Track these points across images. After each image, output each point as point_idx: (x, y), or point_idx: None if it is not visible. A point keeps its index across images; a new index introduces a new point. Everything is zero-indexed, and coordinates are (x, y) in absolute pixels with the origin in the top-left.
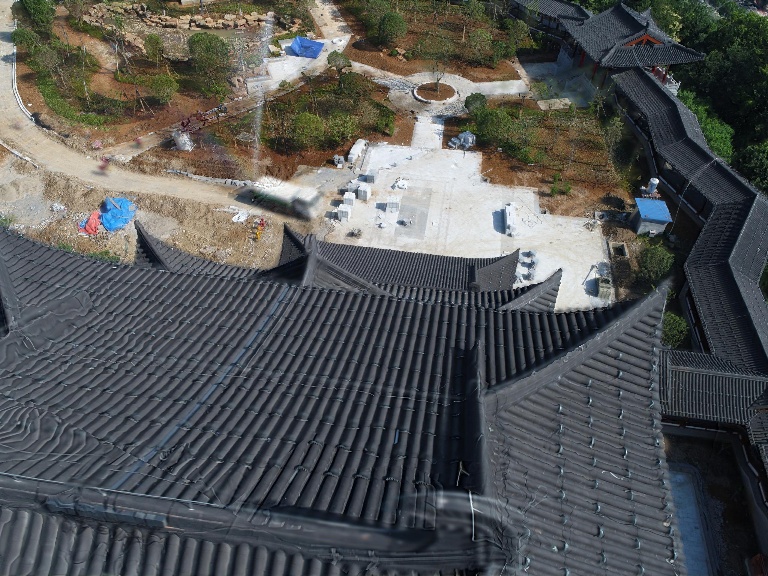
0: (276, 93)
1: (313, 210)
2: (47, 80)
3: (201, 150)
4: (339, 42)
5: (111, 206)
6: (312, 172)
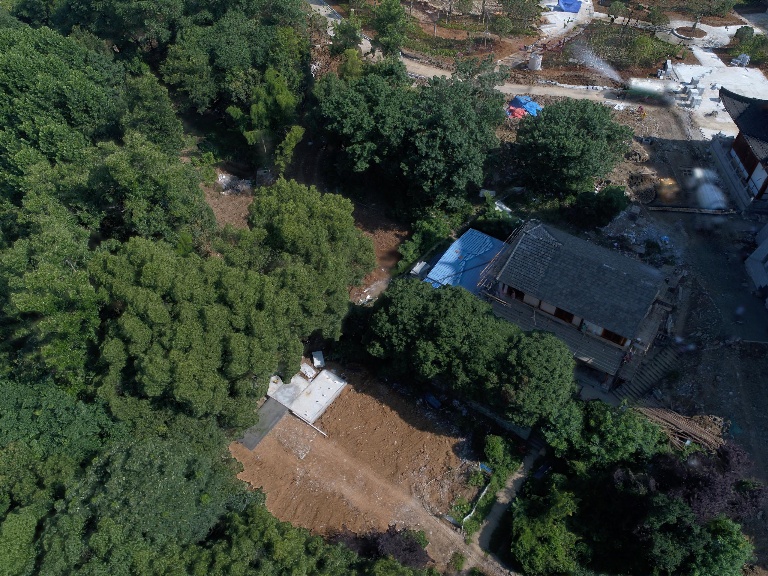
0: (568, 35)
1: (667, 103)
2: None
3: (550, 69)
4: (587, 2)
5: (524, 101)
6: (644, 81)
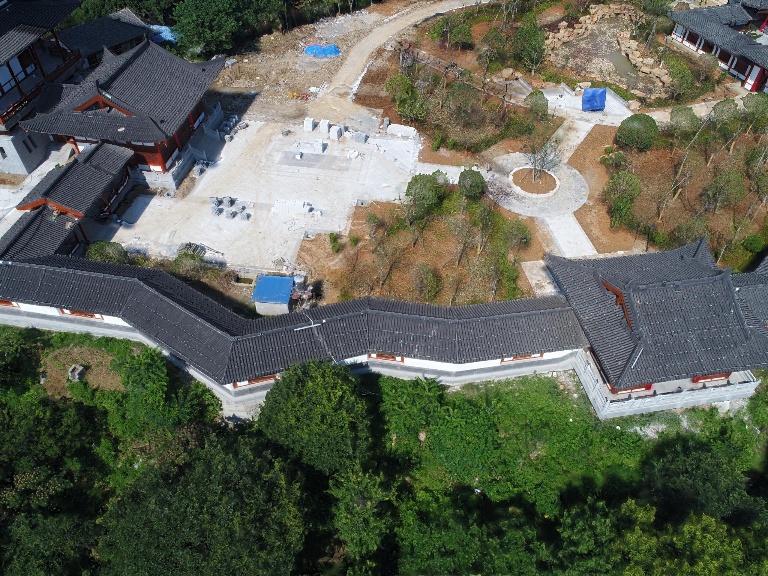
0: None
1: (321, 116)
2: (485, 8)
3: None
4: None
5: None
6: (373, 115)
